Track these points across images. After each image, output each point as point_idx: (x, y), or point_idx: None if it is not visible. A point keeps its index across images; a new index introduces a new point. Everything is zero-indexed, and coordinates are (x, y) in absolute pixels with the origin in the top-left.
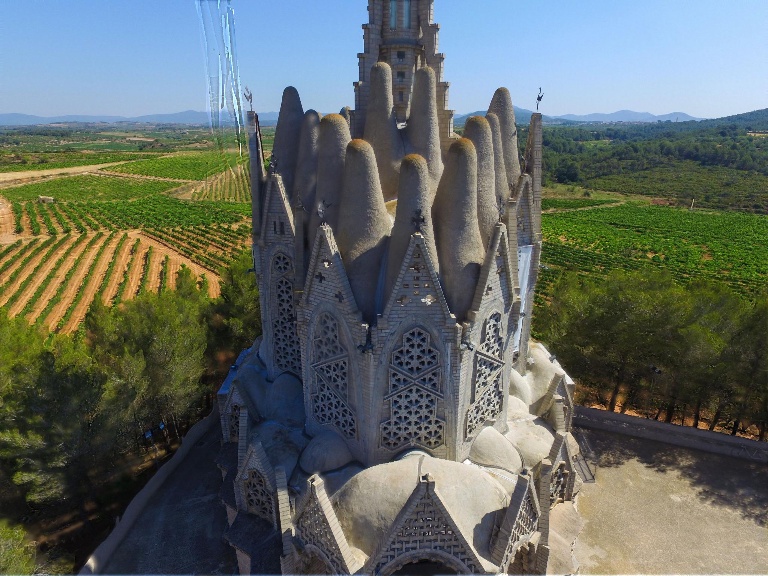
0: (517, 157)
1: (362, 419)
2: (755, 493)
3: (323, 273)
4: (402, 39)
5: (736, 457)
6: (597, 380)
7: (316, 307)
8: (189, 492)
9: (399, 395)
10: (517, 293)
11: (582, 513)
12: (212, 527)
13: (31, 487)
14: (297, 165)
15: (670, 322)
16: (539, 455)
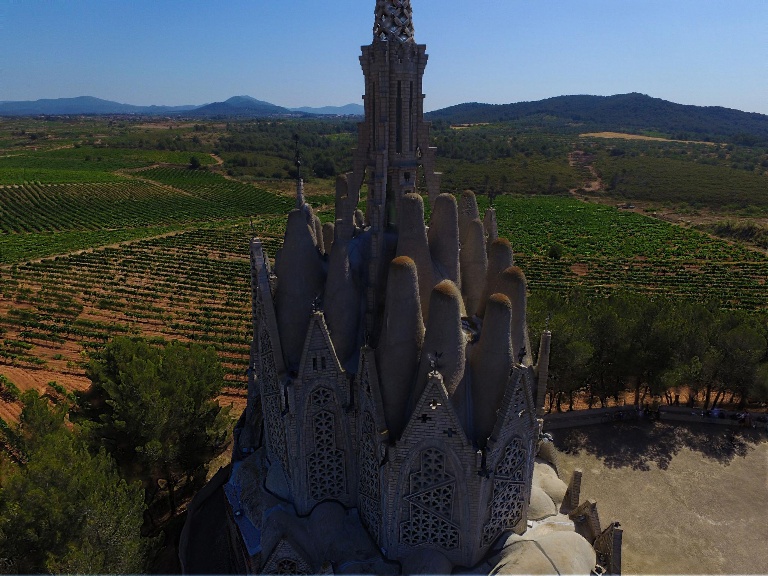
0: None
1: (467, 529)
2: (628, 447)
3: (429, 414)
4: (408, 161)
5: (604, 423)
6: None
7: (416, 445)
8: None
9: (497, 497)
10: None
11: None
12: None
13: None
14: (329, 295)
15: (560, 341)
16: (562, 491)
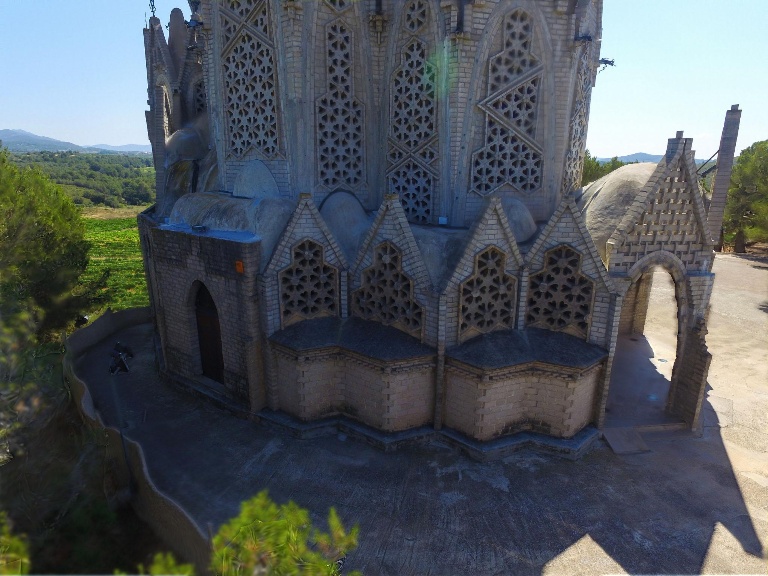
0: None
1: (552, 155)
2: None
3: None
4: None
5: None
6: None
7: (498, 5)
8: (225, 463)
9: None
10: None
11: None
12: (344, 456)
13: None
14: None
15: None
16: None
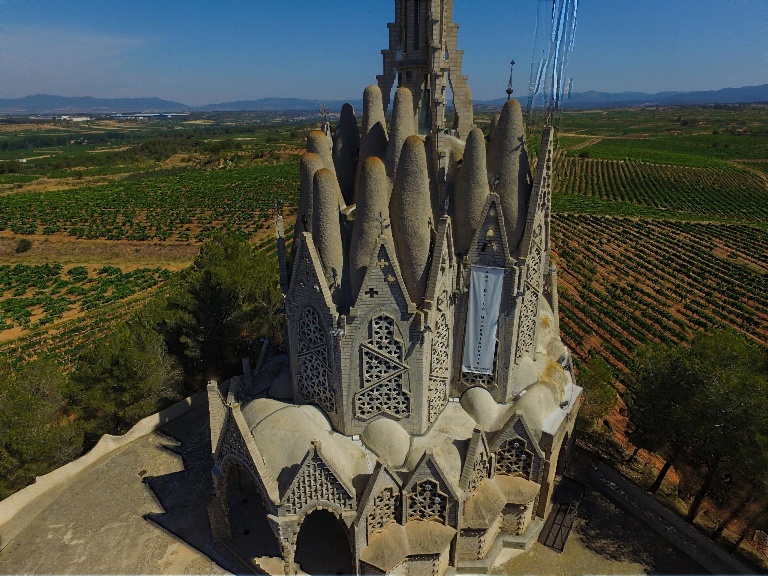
0: (517, 174)
1: None
2: None
3: None
4: (410, 60)
5: None
6: (676, 465)
7: None
8: None
9: None
10: (429, 307)
11: (509, 566)
12: None
13: (189, 347)
14: None
15: (749, 421)
16: None
